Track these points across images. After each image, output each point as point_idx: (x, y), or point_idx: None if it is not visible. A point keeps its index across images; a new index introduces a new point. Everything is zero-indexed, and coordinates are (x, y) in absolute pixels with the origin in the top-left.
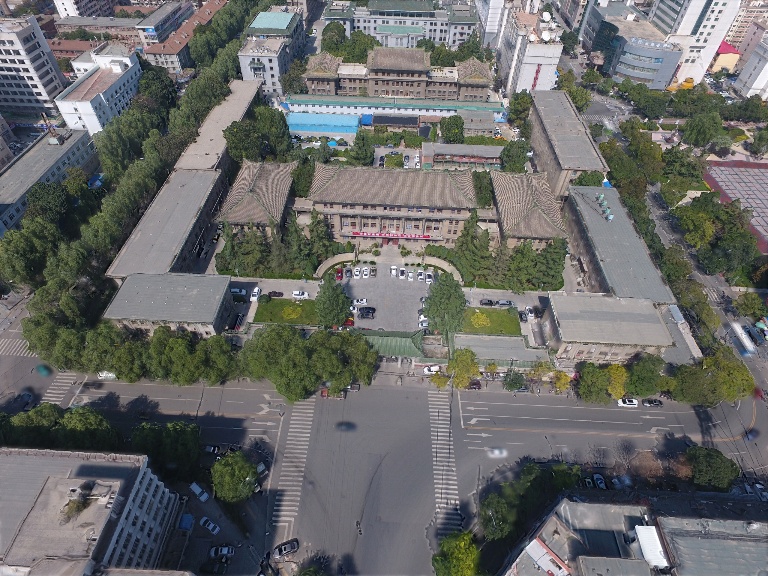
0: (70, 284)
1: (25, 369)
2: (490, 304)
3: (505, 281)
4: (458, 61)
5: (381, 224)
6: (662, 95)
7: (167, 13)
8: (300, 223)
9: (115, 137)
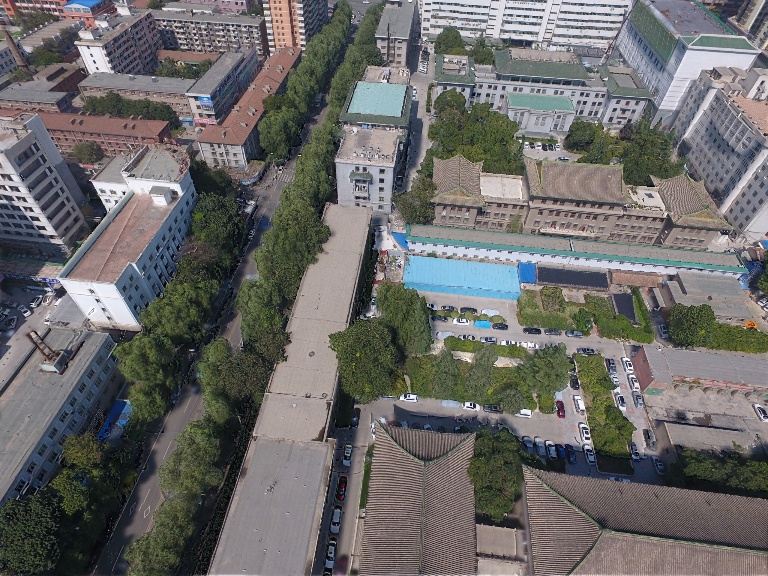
0: None
1: None
2: None
3: None
4: (655, 175)
5: None
6: None
7: (227, 71)
8: None
9: (153, 356)
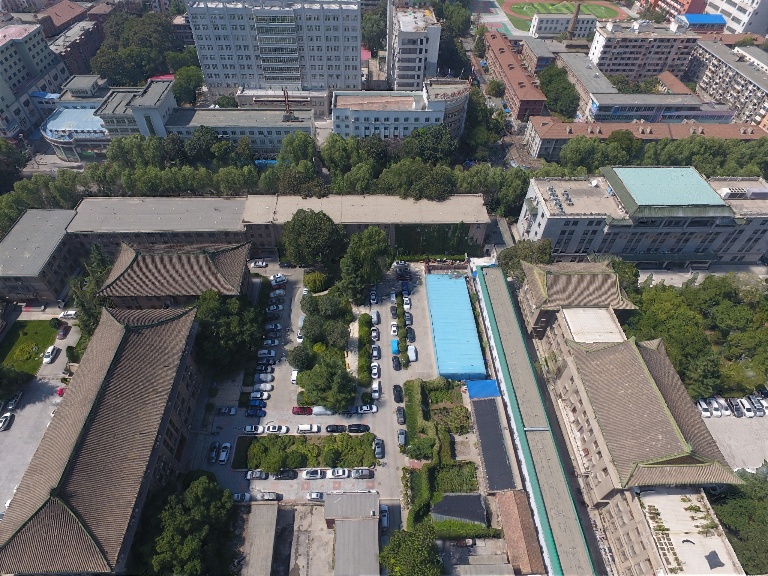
0: None
1: None
2: None
3: None
4: None
5: None
6: None
7: (652, 102)
8: None
9: (294, 144)
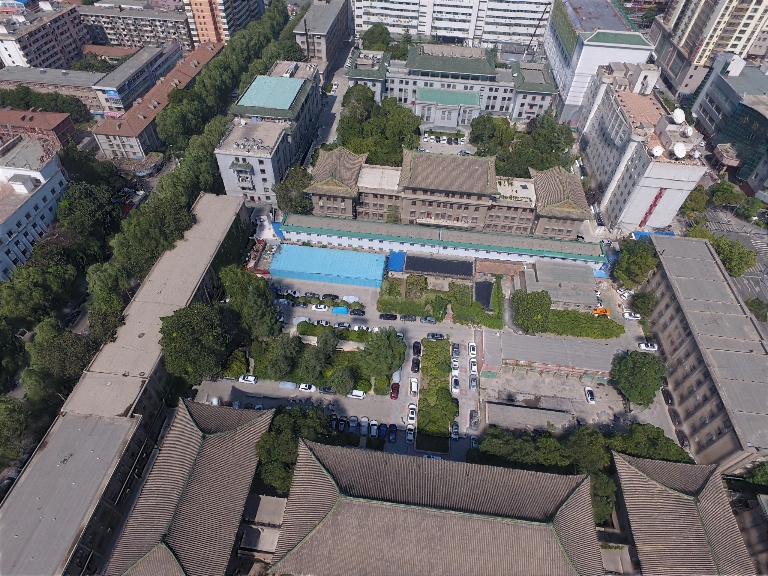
0: None
1: None
2: None
3: None
4: (534, 167)
5: None
6: None
7: (140, 65)
8: (265, 550)
9: None
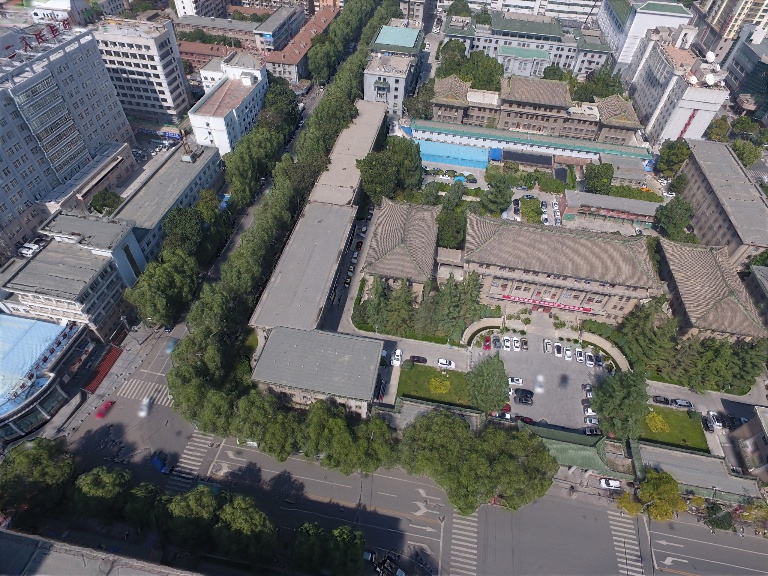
0: (213, 332)
1: (160, 420)
2: (666, 403)
3: (684, 377)
4: (597, 96)
5: (536, 290)
6: None
7: (284, 18)
8: (443, 277)
9: (248, 159)
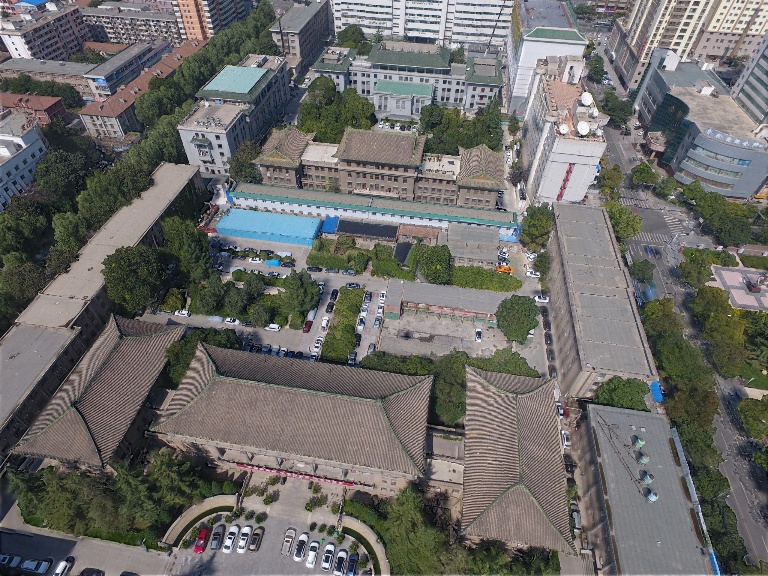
0: None
1: None
2: None
3: None
4: (464, 146)
5: None
6: (745, 211)
7: (129, 58)
8: None
9: None
